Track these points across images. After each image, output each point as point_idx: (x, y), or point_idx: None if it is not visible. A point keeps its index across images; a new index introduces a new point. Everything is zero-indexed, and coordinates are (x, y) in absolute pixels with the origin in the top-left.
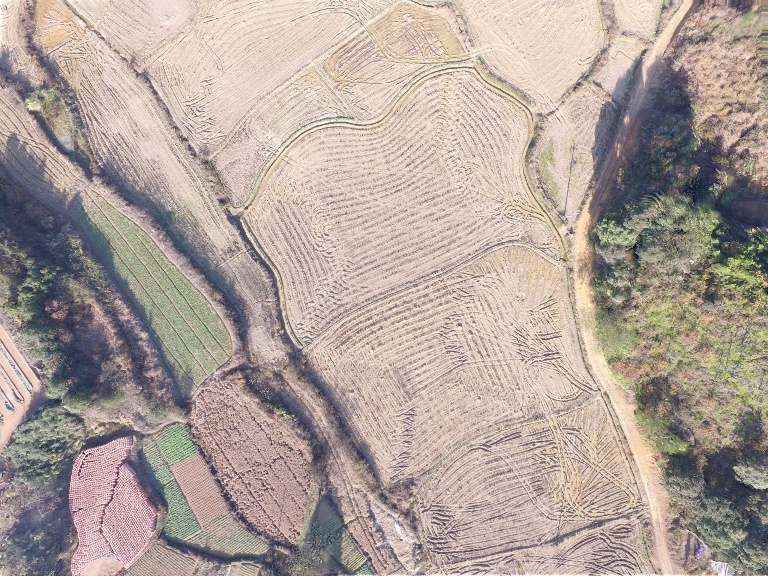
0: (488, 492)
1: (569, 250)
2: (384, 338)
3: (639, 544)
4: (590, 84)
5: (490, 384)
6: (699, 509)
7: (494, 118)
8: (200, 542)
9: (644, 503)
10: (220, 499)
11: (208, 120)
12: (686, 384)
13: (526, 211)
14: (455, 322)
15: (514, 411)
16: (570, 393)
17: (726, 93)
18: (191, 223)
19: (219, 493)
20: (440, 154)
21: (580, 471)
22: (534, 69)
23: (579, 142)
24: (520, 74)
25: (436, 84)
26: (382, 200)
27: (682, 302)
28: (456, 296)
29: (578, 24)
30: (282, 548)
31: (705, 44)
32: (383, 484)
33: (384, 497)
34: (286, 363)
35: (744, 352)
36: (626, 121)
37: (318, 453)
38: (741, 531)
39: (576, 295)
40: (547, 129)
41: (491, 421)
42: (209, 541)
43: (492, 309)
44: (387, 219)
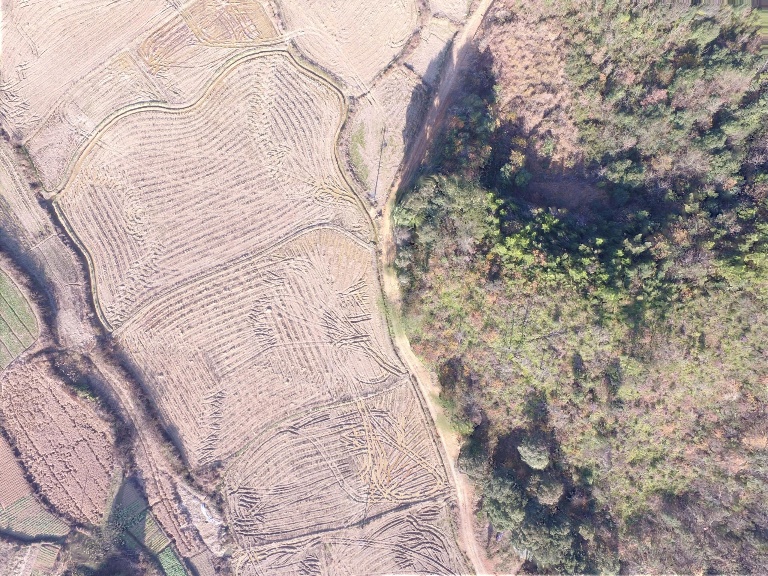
0: (295, 474)
1: (378, 233)
2: (194, 321)
3: (446, 526)
4: (401, 67)
5: (298, 367)
6: (486, 490)
7: (307, 101)
8: (2, 523)
9: (451, 485)
10: (22, 481)
11: (22, 105)
12: (476, 365)
13: (337, 194)
14: (265, 305)
15: (322, 394)
16: (378, 376)
17: (530, 74)
18: (3, 207)
19: (22, 475)
20: (252, 137)
21: (387, 453)
22: (346, 52)
23: (390, 125)
24: (332, 57)
25: (249, 68)
26: (194, 183)
27: (468, 282)
28: (266, 279)
29: (391, 7)
30: (83, 529)
31: (509, 25)
32: (191, 466)
33: (190, 479)
34: (94, 346)
35: (525, 332)
36: (436, 103)
37: (122, 435)
38: (517, 511)
39: (384, 277)
40: (358, 112)
41: (299, 404)
42: (11, 522)
43: (302, 292)
44: (198, 202)
